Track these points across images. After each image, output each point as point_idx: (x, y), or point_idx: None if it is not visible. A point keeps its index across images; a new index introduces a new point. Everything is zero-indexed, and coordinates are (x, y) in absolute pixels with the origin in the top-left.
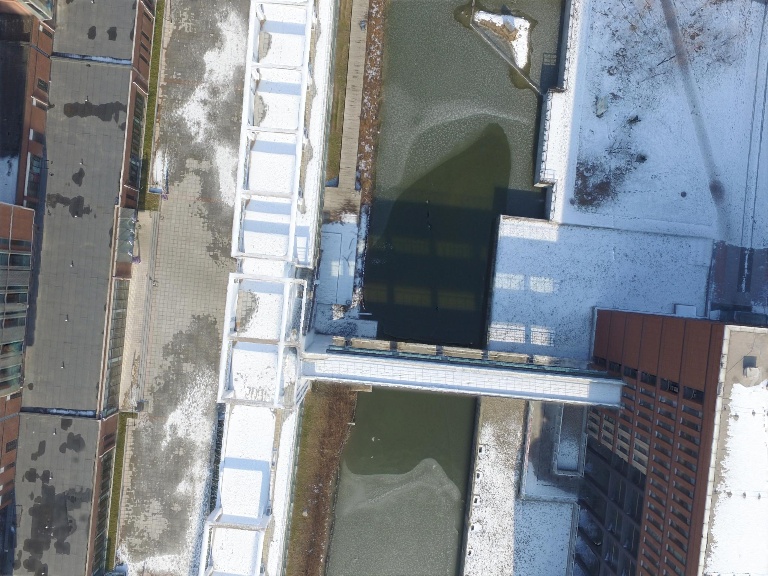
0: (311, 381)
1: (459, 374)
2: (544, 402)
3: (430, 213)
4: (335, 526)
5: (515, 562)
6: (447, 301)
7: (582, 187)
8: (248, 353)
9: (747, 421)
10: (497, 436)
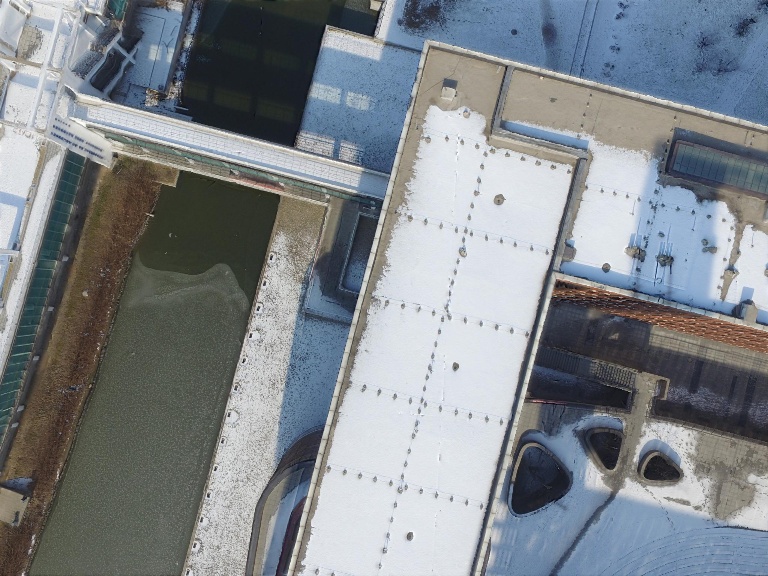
0: (113, 161)
1: (231, 142)
2: (341, 217)
3: (263, 20)
4: (118, 316)
5: (288, 378)
6: (266, 109)
7: (411, 8)
8: (24, 88)
9: (439, 146)
10: (290, 246)
